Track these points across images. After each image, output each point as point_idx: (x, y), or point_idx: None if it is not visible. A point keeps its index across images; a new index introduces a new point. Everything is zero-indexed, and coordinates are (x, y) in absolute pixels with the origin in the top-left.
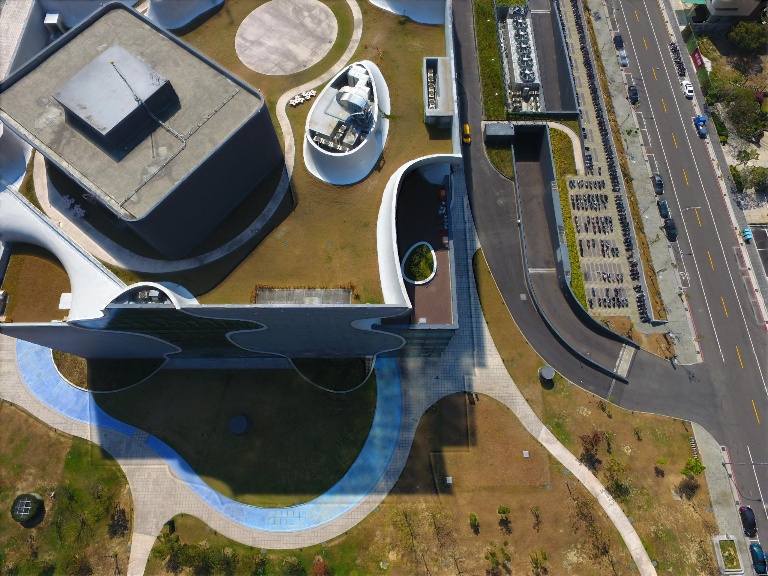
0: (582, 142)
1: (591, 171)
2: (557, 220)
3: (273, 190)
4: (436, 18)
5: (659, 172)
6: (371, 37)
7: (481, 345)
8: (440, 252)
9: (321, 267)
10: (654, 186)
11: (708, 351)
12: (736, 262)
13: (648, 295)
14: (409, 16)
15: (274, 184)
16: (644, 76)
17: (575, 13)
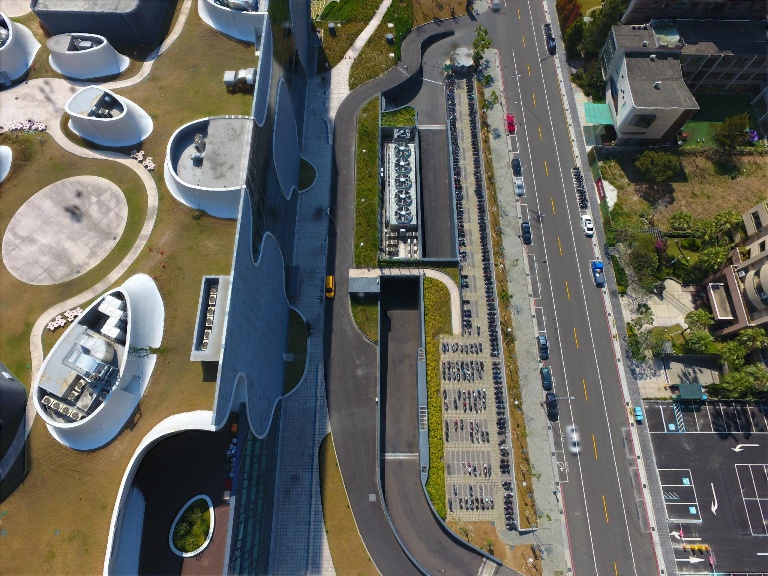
0: (460, 296)
1: (468, 331)
2: (419, 399)
3: (3, 452)
4: (237, 212)
5: (546, 331)
6: (160, 234)
7: (316, 562)
8: (222, 508)
9: (38, 568)
10: (539, 349)
11: (581, 568)
12: (624, 449)
13: (516, 496)
14: (205, 210)
15: (7, 443)
16: (541, 208)
17: (472, 131)
